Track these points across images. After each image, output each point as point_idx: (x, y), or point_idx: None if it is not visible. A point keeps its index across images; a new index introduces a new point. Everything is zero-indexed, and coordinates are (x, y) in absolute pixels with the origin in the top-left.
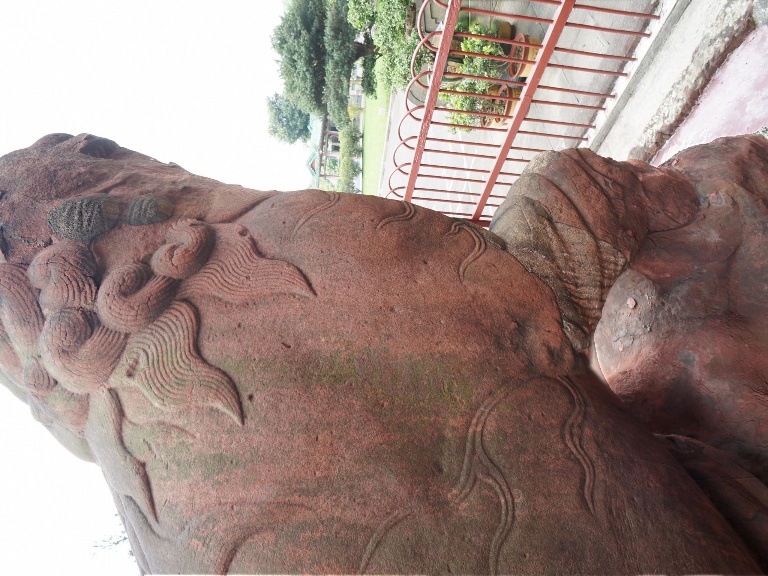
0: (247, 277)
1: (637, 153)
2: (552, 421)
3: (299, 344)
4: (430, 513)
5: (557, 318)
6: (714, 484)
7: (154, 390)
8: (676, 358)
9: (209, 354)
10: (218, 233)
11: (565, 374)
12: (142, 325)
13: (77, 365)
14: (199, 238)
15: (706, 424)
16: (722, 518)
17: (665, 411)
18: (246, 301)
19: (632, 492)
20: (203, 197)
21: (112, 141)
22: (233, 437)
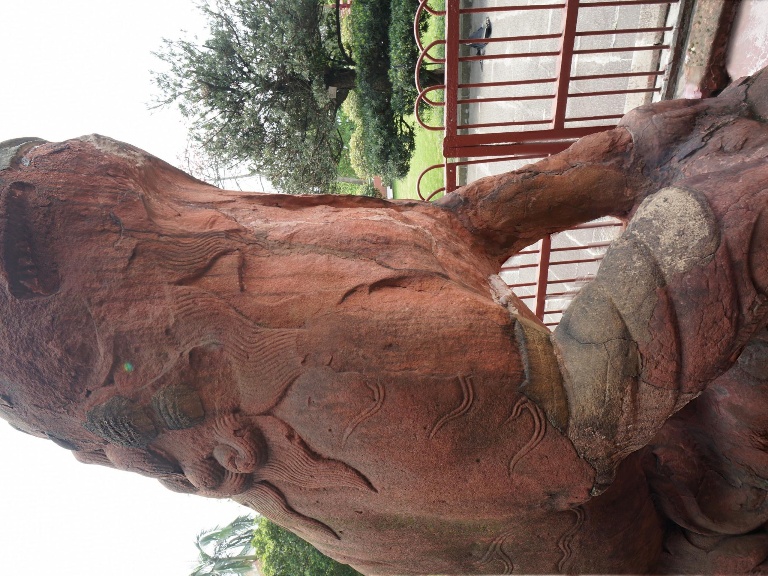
0: (311, 476)
1: None
2: (554, 537)
3: (369, 511)
4: (462, 569)
5: None
6: (662, 499)
7: (269, 517)
8: (710, 385)
9: None
10: (264, 433)
11: (578, 505)
12: None
13: None
14: (251, 450)
15: (700, 417)
16: (651, 521)
17: None
18: None
19: (590, 558)
20: (220, 369)
21: (8, 203)
22: (335, 542)
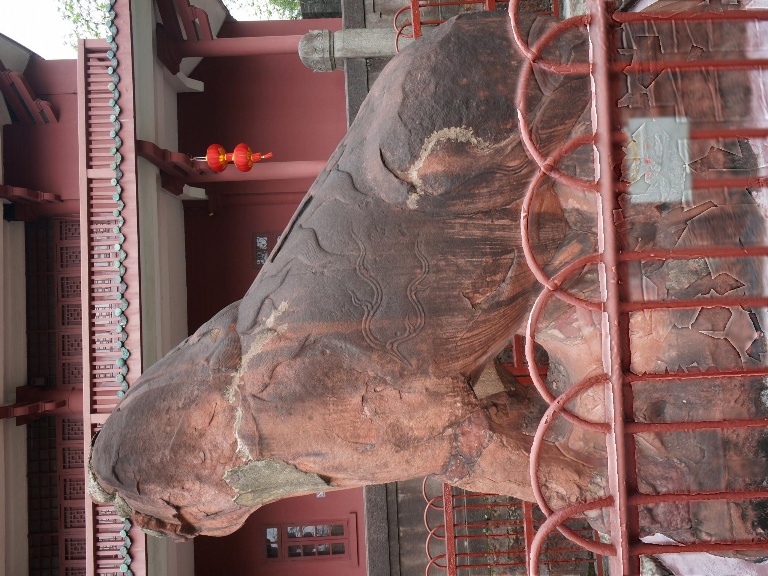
0: None
1: None
2: None
3: None
4: None
5: None
6: None
7: None
8: None
9: None
10: None
11: None
12: None
13: None
14: None
15: None
16: None
17: None
18: None
19: None
20: None
21: None
22: None
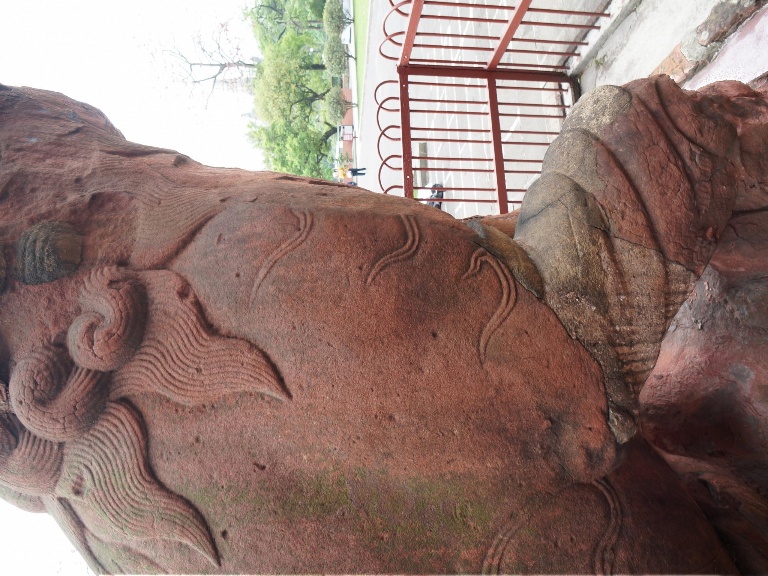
0: (197, 369)
1: (724, 13)
2: (582, 547)
3: (275, 463)
4: None
5: (602, 408)
6: (745, 552)
7: (109, 517)
8: (726, 370)
9: (166, 477)
10: (149, 292)
11: (603, 475)
12: (76, 436)
13: (11, 478)
14: (123, 310)
15: (742, 442)
16: None
17: (698, 418)
18: (201, 403)
19: None
20: (122, 215)
21: None
22: None
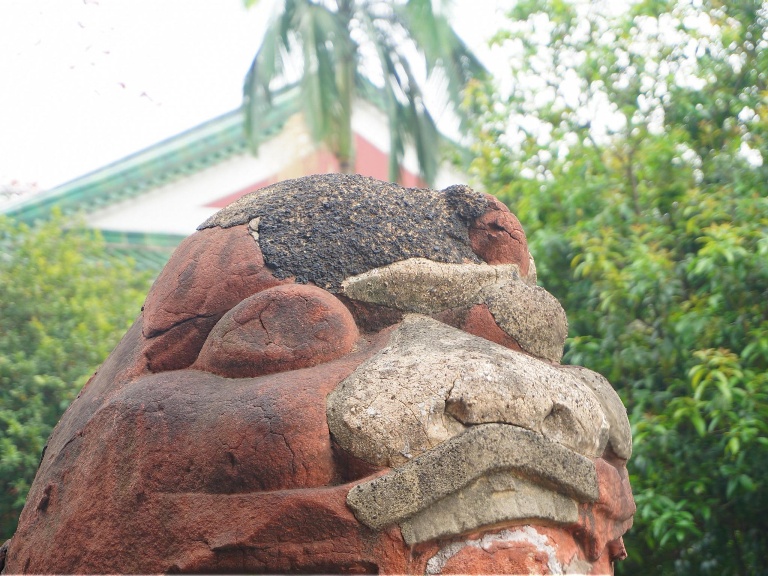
0: None
1: None
2: None
3: None
4: None
5: None
6: None
7: None
8: None
9: None
10: None
11: None
12: None
13: None
14: None
15: None
16: None
17: None
18: None
19: None
20: None
21: (323, 565)
22: None
